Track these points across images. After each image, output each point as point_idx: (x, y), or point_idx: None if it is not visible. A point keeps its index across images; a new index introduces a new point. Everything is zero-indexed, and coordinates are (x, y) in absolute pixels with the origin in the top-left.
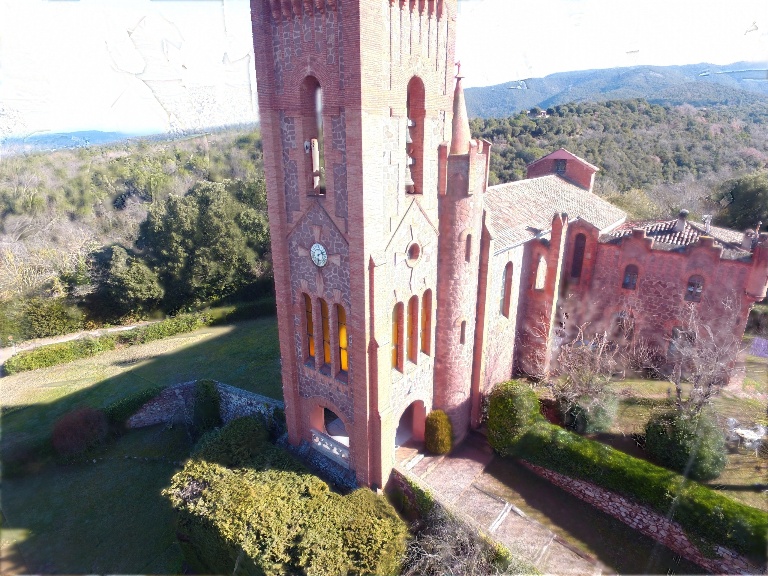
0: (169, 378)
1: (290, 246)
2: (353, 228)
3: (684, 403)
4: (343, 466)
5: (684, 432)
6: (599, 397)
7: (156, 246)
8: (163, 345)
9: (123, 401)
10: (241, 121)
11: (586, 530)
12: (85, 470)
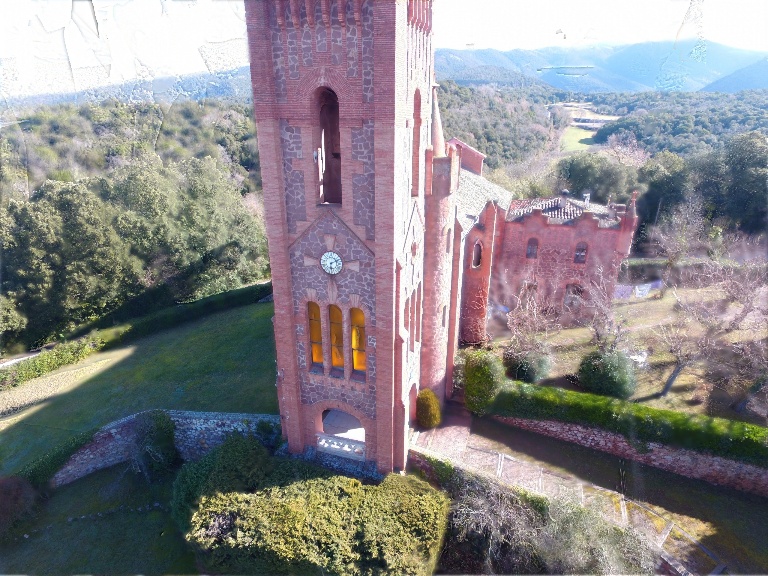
0: (86, 419)
1: (292, 257)
2: (381, 235)
3: (603, 344)
4: (357, 460)
5: (611, 366)
6: (541, 351)
7: (5, 266)
8: (49, 383)
9: (45, 458)
10: (62, 103)
11: (560, 458)
12: (17, 550)
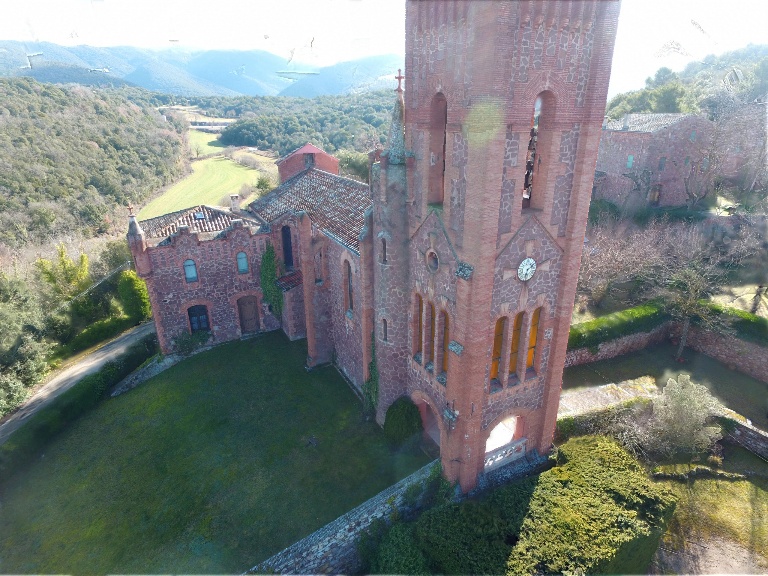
0: None
1: None
2: (578, 229)
3: None
4: (519, 458)
5: None
6: None
7: None
8: None
9: None
10: None
11: (570, 381)
12: None
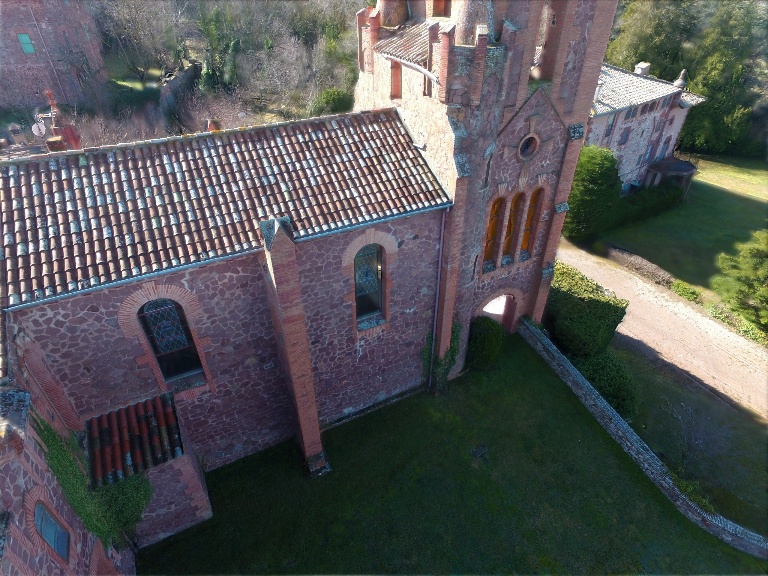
0: None
1: None
2: None
3: None
4: None
5: None
6: None
7: None
8: None
9: None
10: None
11: None
12: None
